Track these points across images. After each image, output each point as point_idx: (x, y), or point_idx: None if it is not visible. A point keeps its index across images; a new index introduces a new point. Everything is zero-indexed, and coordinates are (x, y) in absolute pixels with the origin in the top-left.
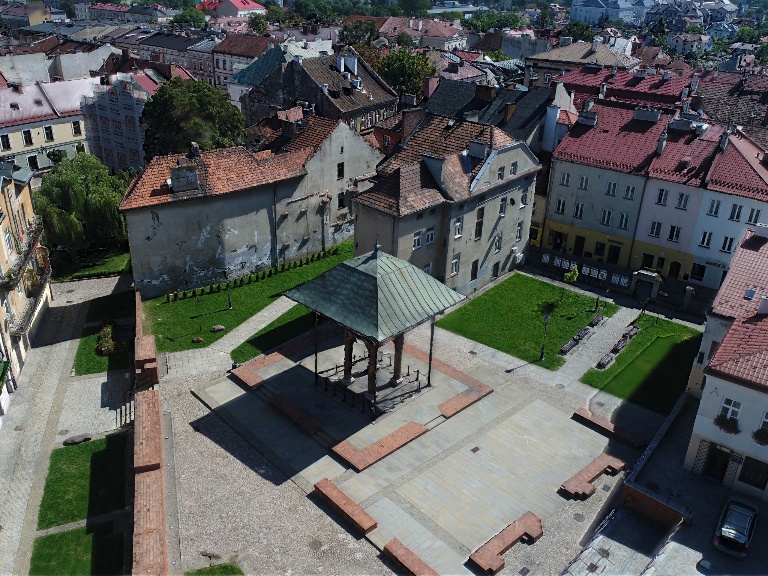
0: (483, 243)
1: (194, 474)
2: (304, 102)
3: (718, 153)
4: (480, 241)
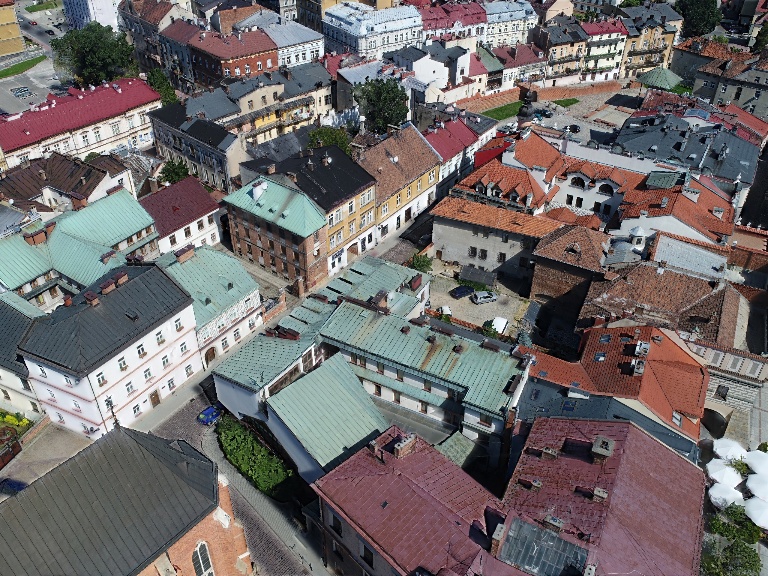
0: (740, 103)
1: None
2: None
3: None
4: (738, 101)
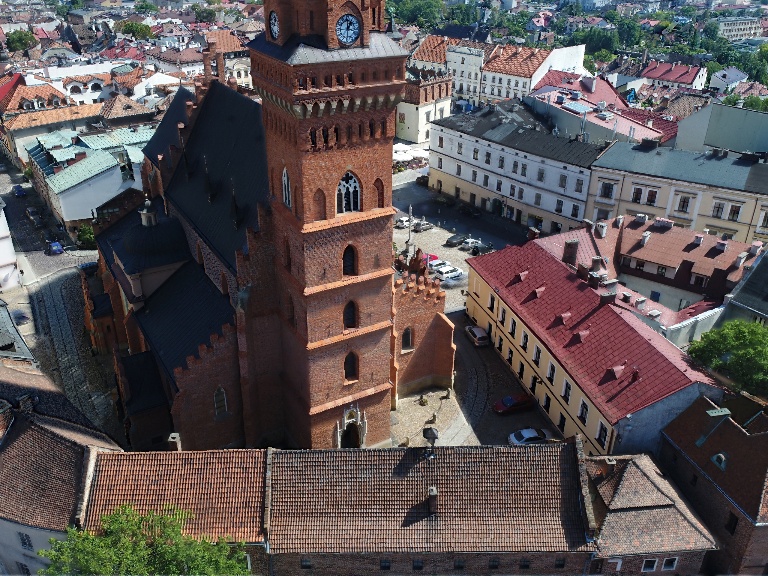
0: None
1: None
2: (69, 41)
3: (123, 53)
4: None
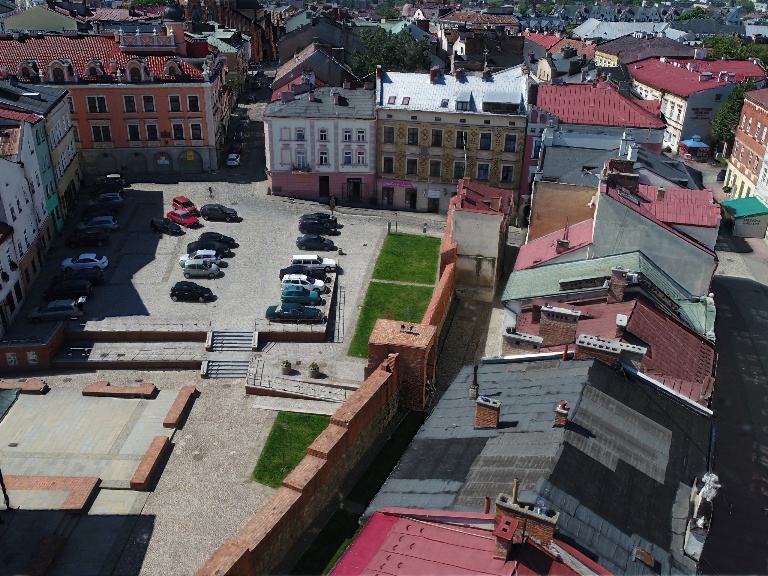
0: None
1: (190, 575)
2: None
3: None
4: None
